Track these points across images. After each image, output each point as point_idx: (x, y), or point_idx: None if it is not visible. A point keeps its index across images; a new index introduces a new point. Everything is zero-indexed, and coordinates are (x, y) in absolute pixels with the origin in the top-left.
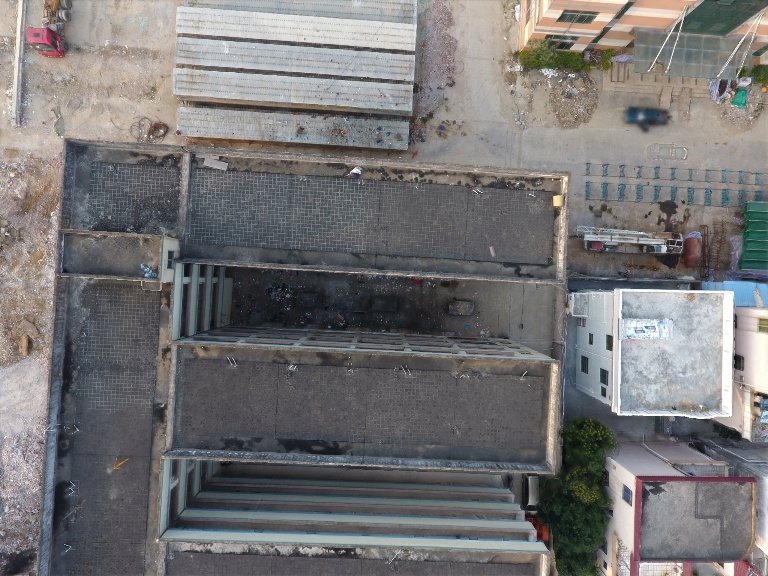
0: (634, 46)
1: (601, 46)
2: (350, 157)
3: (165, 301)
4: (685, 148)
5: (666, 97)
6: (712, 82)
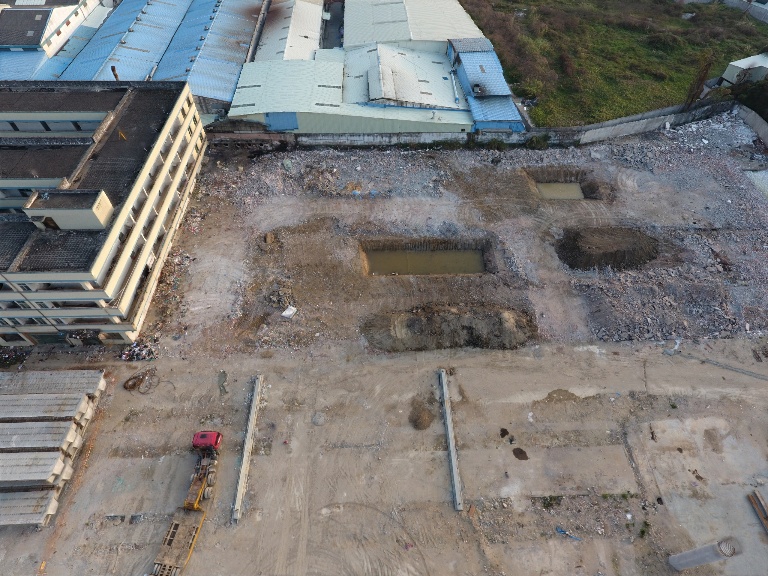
0: None
1: None
2: None
3: None
4: None
5: None
6: None
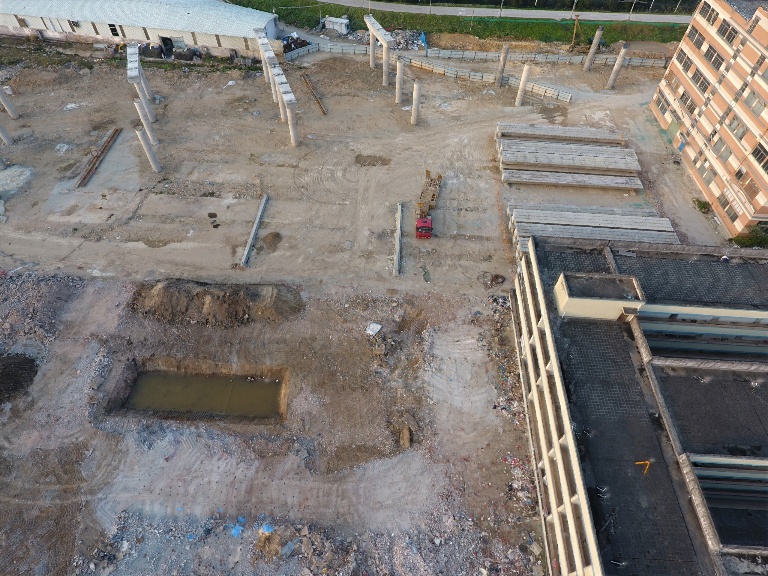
0: None
1: None
2: None
3: (626, 334)
4: None
5: None
6: None
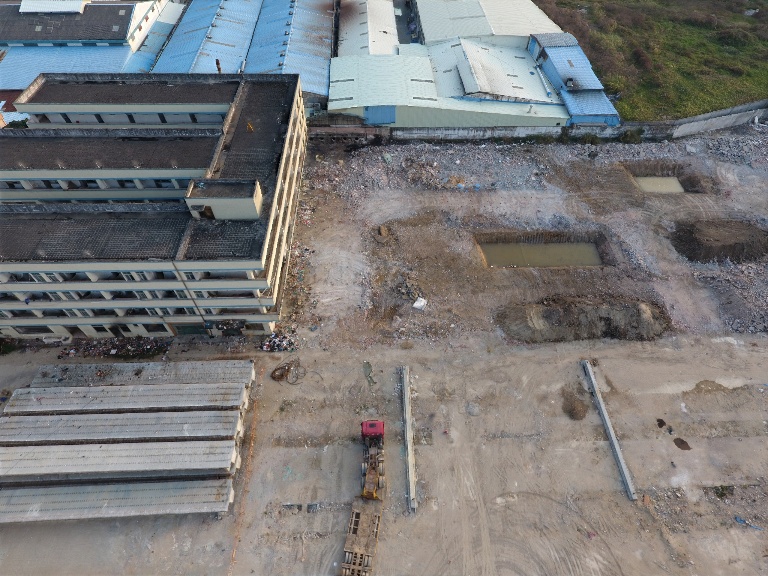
0: None
1: None
2: (41, 263)
3: None
4: None
5: None
6: None
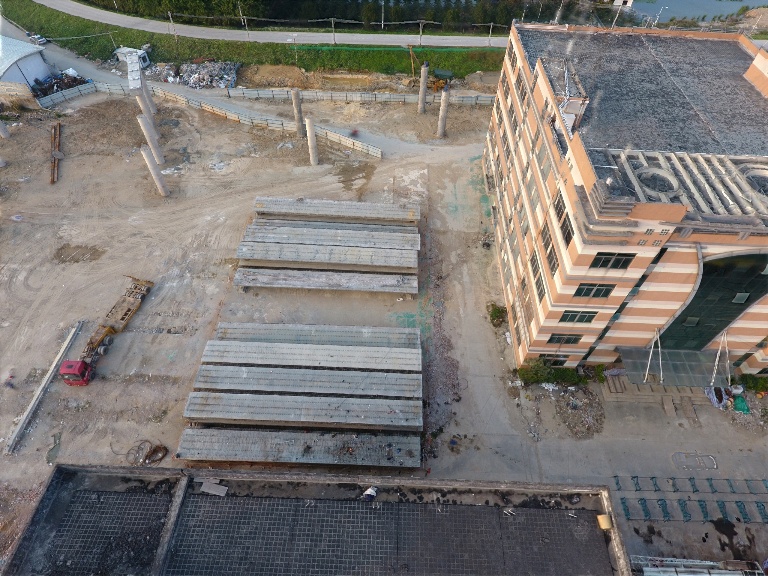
0: (622, 361)
1: (591, 362)
2: None
3: None
4: (711, 456)
5: (669, 405)
6: (706, 390)
